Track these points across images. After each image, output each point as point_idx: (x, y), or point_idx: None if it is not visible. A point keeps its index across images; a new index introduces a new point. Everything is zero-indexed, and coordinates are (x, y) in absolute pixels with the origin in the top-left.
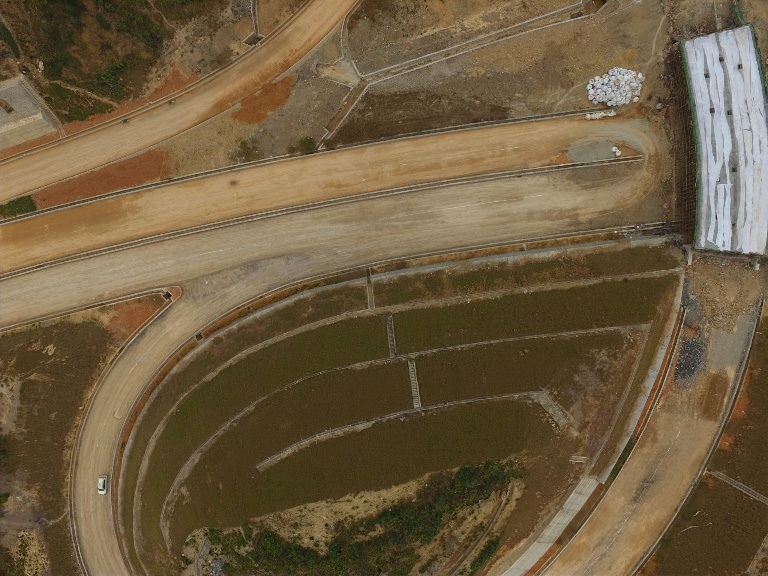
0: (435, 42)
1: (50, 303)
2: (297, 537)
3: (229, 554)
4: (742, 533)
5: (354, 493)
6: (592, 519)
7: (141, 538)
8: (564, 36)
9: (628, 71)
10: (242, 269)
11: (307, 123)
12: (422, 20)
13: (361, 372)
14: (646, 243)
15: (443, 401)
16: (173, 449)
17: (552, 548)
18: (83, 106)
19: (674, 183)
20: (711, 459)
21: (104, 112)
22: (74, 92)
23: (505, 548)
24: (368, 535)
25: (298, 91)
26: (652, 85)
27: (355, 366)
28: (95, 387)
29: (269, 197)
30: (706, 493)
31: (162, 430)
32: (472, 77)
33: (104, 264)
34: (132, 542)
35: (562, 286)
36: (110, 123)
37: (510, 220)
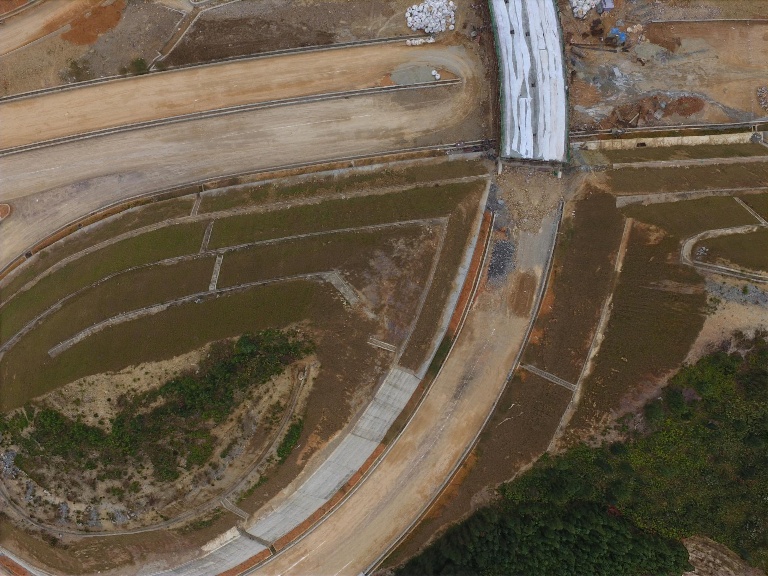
0: None
1: None
2: (81, 415)
3: (19, 443)
4: (545, 416)
5: (135, 365)
6: (416, 418)
7: None
8: None
9: (441, 0)
10: (74, 187)
11: (138, 45)
12: None
13: (170, 267)
14: (463, 157)
15: (238, 283)
16: None
17: (378, 448)
18: None
19: (491, 105)
20: (523, 353)
21: None
22: None
23: (319, 440)
24: (150, 407)
25: (129, 14)
26: (465, 14)
27: (164, 262)
28: None
29: (101, 116)
30: (519, 386)
31: None
32: (301, 6)
33: None
34: None
35: (378, 192)
36: None
37: (339, 139)
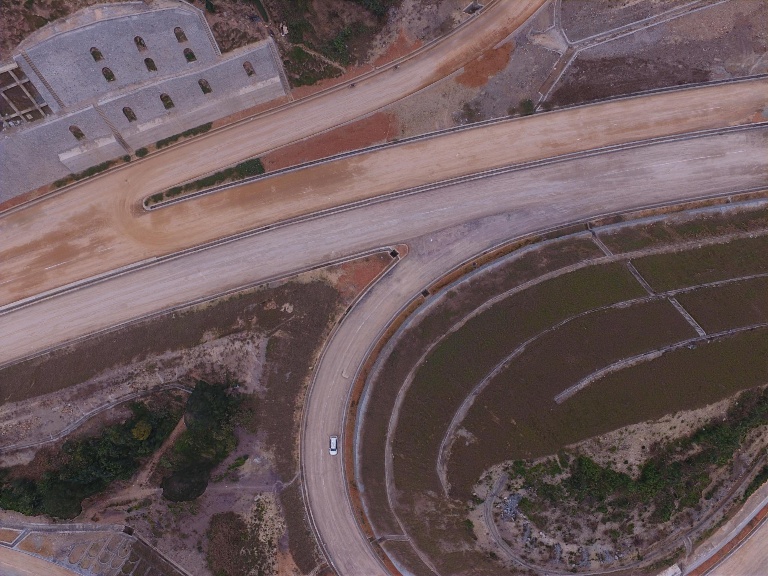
0: (637, 12)
1: (276, 264)
2: (612, 462)
3: (530, 487)
4: None
5: (672, 413)
6: None
7: (395, 491)
8: (750, 7)
9: None
10: (465, 226)
11: (526, 86)
12: None
13: (626, 310)
14: None
15: (726, 329)
16: (436, 396)
17: None
18: (315, 71)
19: None
20: None
21: (332, 77)
22: (312, 56)
23: None
24: (686, 454)
25: (516, 56)
26: None
27: (619, 305)
28: (324, 346)
29: (490, 157)
30: None
31: (411, 381)
32: (671, 44)
33: (330, 224)
34: (384, 496)
35: None
36: (337, 87)
37: (714, 175)
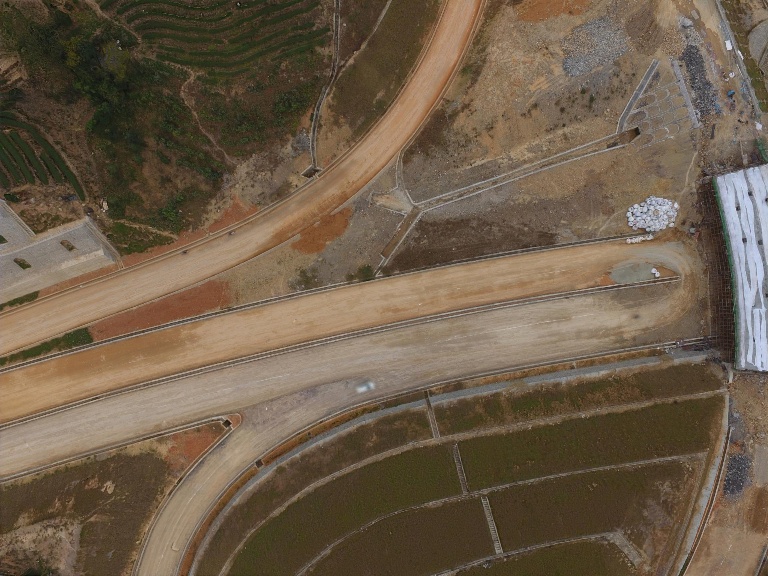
0: (484, 172)
1: (106, 435)
2: None
3: None
4: None
5: None
6: None
7: None
8: (602, 165)
9: (664, 200)
10: (302, 394)
11: (365, 251)
12: (472, 153)
13: (436, 511)
14: (688, 361)
15: (524, 546)
16: None
17: None
18: (144, 240)
19: (709, 301)
20: (762, 571)
21: (164, 244)
22: (137, 229)
23: None
24: None
25: (356, 221)
26: (686, 212)
27: (430, 505)
28: (152, 520)
29: (328, 323)
30: None
31: (229, 569)
32: (519, 204)
33: (162, 393)
34: None
35: (617, 410)
36: (169, 254)
37: (560, 339)
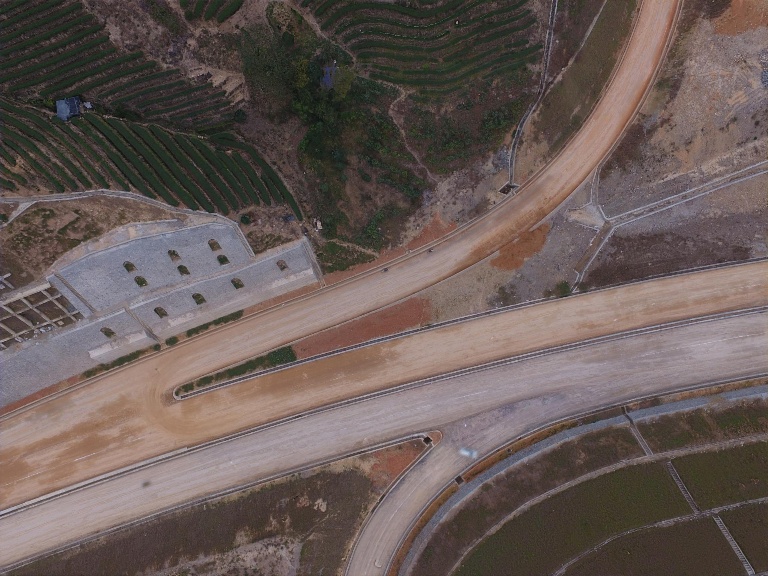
0: (675, 186)
1: (308, 452)
2: None
3: None
4: None
5: None
6: None
7: None
8: None
9: None
10: (500, 411)
11: (562, 268)
12: (667, 168)
13: (669, 530)
14: None
15: None
16: None
17: None
18: (348, 258)
19: None
20: None
21: (365, 262)
22: (345, 248)
23: None
24: None
25: (553, 237)
26: None
27: (662, 524)
28: (356, 536)
29: (525, 339)
30: None
31: None
32: (710, 218)
33: (363, 411)
34: None
35: None
36: (370, 272)
37: (754, 354)
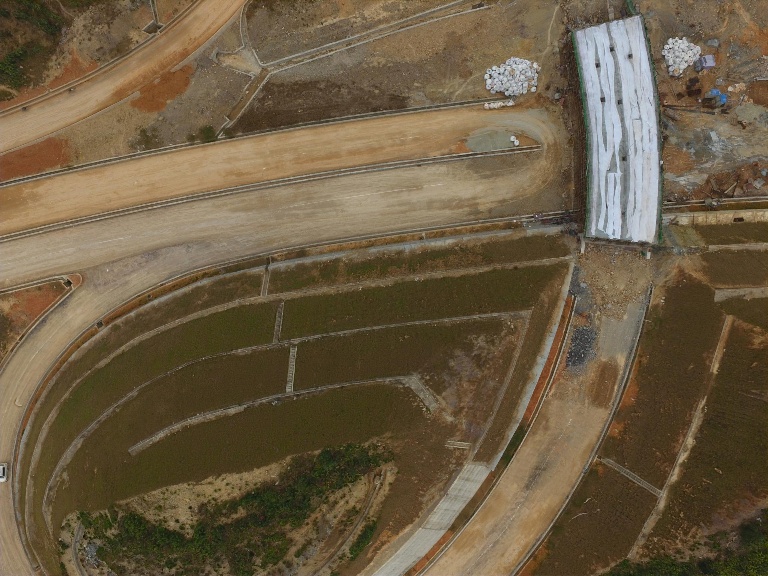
0: (336, 32)
1: None
2: (162, 520)
3: None
4: (625, 519)
5: (216, 476)
6: (485, 506)
7: (33, 524)
8: (465, 26)
9: (524, 61)
10: (143, 257)
11: (206, 111)
12: (321, 9)
13: (243, 358)
14: (542, 232)
15: (315, 385)
16: (60, 435)
17: (446, 535)
18: None
19: (573, 173)
20: (601, 446)
21: (3, 100)
22: None
23: (389, 534)
24: (230, 518)
25: (197, 79)
26: (549, 75)
27: (238, 352)
28: None
29: (170, 185)
30: (596, 480)
31: (55, 417)
32: (373, 67)
33: (5, 252)
34: (25, 529)
35: (453, 274)
36: (10, 111)
37: (410, 209)
